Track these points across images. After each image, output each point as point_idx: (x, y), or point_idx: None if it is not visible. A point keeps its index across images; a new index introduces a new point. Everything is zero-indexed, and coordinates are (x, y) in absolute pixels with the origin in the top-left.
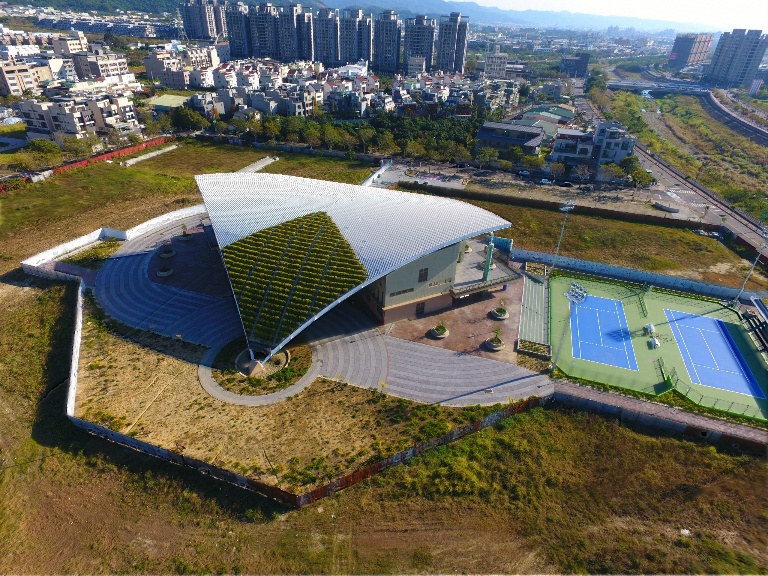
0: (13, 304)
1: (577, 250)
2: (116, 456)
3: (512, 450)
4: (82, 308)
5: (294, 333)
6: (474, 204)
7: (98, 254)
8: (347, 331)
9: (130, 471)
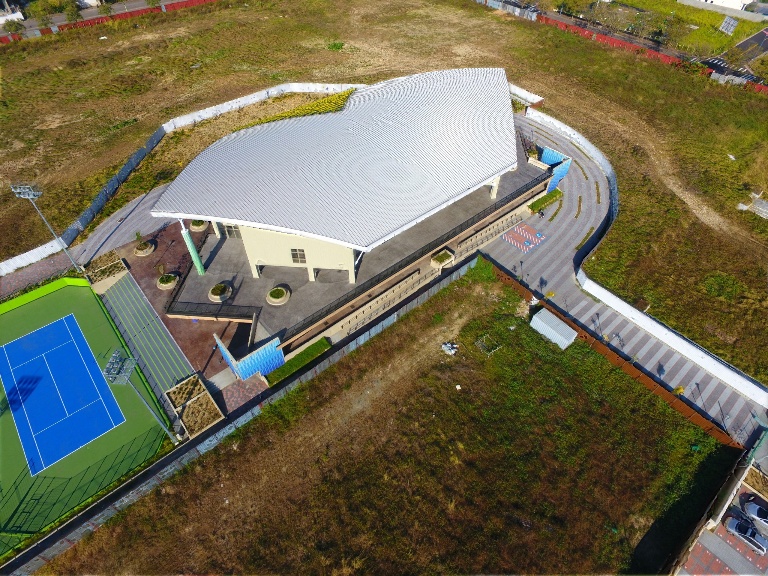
0: None
1: None
2: None
3: None
4: None
5: None
6: None
7: None
8: None
9: None
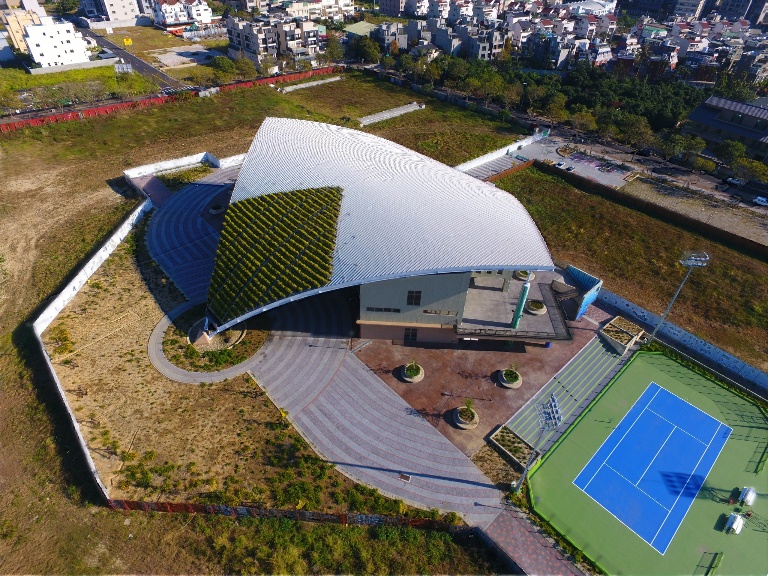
0: (99, 207)
1: (724, 322)
2: (40, 377)
3: (359, 574)
4: (132, 226)
5: (241, 317)
6: (617, 211)
7: (187, 177)
8: (317, 331)
9: (37, 396)
